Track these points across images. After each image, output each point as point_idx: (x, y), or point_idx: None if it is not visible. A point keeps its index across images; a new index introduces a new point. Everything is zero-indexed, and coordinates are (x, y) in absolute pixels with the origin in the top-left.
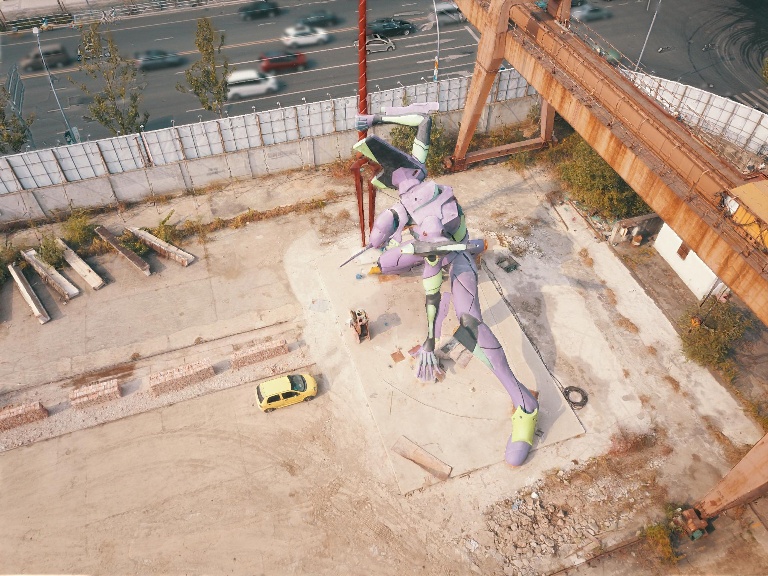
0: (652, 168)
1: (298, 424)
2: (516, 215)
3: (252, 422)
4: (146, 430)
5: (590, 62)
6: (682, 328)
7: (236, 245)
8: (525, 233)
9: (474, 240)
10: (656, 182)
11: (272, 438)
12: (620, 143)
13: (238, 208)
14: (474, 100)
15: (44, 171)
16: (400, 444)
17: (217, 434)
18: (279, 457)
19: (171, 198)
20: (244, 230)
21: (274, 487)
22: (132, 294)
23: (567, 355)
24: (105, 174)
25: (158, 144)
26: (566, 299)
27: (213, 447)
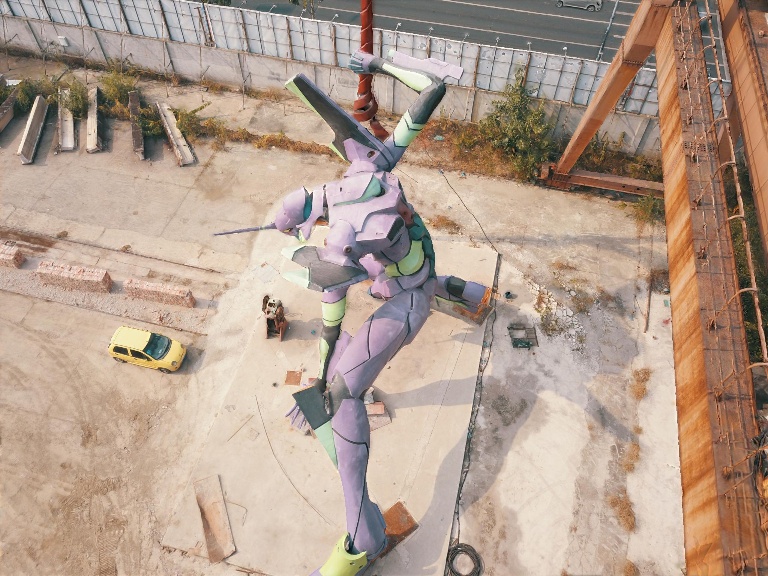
0: (704, 306)
1: (135, 392)
2: (588, 278)
3: (97, 362)
4: (8, 313)
5: (765, 92)
6: (684, 573)
7: (243, 165)
8: (580, 307)
9: (474, 283)
10: (696, 333)
11: (99, 391)
12: (690, 239)
13: (278, 127)
14: (598, 98)
15: (109, 14)
16: (207, 483)
17: (58, 355)
18: (88, 416)
19: (226, 90)
20: (264, 153)
21: (56, 446)
22: (113, 171)
23: (501, 500)
24: (165, 38)
25: (221, 23)
26: (563, 424)
27: (43, 367)
